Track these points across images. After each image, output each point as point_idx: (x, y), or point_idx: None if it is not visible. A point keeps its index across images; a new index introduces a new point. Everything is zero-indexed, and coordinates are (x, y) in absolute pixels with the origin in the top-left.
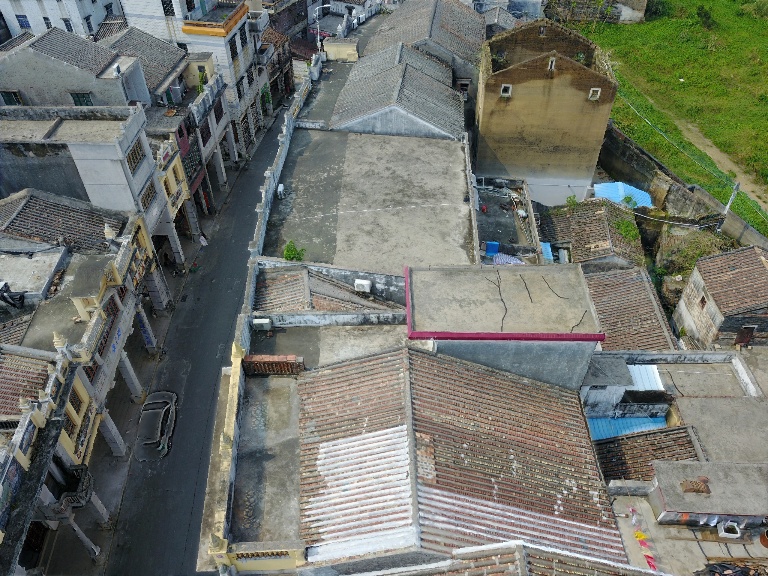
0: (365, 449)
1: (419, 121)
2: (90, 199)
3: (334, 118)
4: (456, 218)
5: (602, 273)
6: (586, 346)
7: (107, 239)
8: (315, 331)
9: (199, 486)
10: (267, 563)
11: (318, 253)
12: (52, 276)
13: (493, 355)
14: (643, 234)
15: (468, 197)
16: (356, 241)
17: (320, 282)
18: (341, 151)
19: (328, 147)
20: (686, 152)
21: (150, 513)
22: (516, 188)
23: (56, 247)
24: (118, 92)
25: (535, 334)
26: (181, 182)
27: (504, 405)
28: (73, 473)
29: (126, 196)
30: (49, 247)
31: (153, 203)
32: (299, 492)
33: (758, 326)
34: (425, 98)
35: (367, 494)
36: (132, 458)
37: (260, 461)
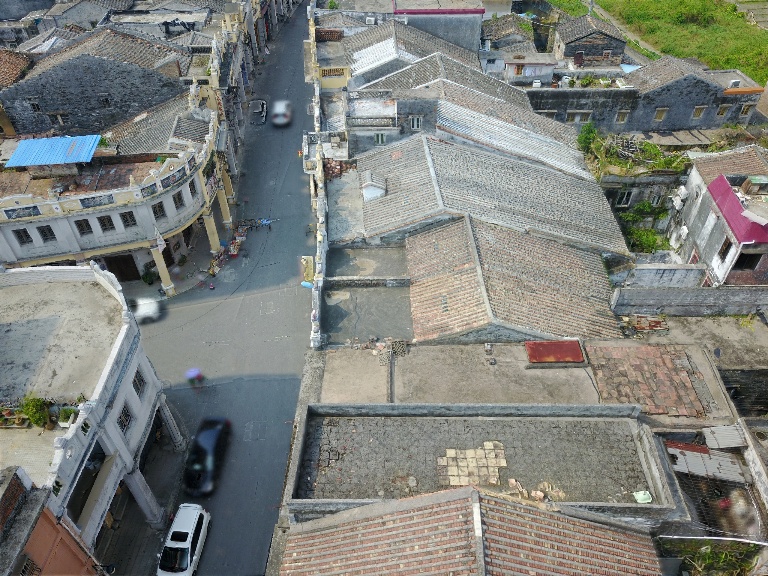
0: None
1: None
2: None
3: None
4: None
5: (509, 47)
6: (477, 19)
7: None
8: None
9: (284, 133)
10: (334, 82)
11: None
12: (206, 18)
13: (434, 26)
14: (539, 37)
15: None
16: (366, 8)
17: (348, 19)
18: None
19: None
20: (580, 9)
21: (260, 141)
22: None
23: (204, 8)
24: None
25: (453, 9)
26: (257, 4)
27: (439, 47)
28: (232, 90)
29: None
30: (200, 9)
31: (247, 3)
32: None
33: (584, 52)
34: None
35: (376, 56)
36: (245, 126)
37: (327, 60)
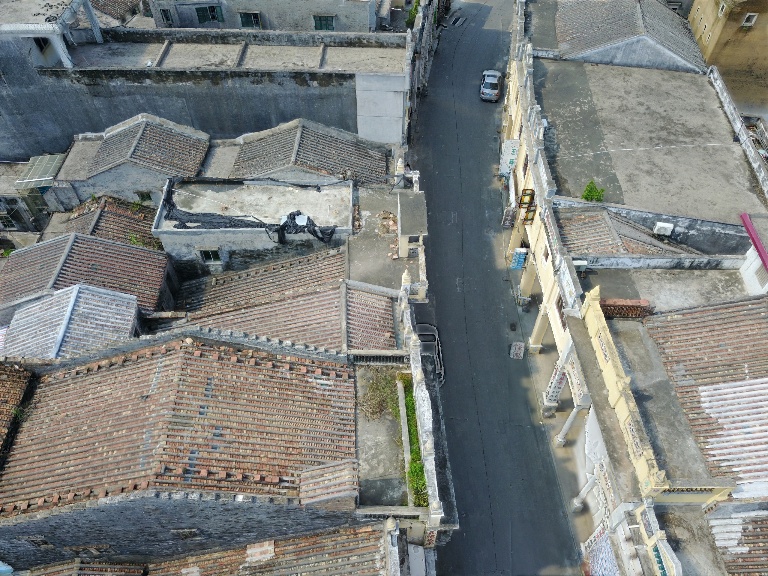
0: (757, 395)
1: (666, 52)
2: (358, 131)
3: (563, 46)
4: (733, 159)
5: None
6: None
7: (398, 174)
8: (626, 274)
9: (481, 415)
10: (684, 497)
11: (605, 193)
12: (353, 211)
13: None
14: None
15: (737, 137)
16: (639, 182)
17: (621, 224)
18: (584, 83)
19: (568, 78)
20: None
21: None
22: (748, 125)
23: (344, 181)
24: (364, 16)
25: None
26: (406, 111)
27: None
28: None
29: (396, 129)
30: (337, 181)
31: None
32: (692, 432)
33: None
34: (663, 26)
35: None
36: None
37: (640, 401)
